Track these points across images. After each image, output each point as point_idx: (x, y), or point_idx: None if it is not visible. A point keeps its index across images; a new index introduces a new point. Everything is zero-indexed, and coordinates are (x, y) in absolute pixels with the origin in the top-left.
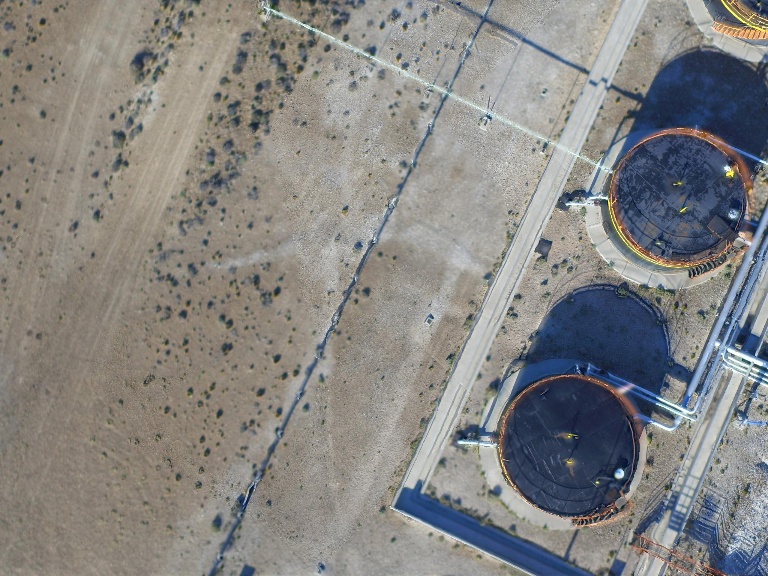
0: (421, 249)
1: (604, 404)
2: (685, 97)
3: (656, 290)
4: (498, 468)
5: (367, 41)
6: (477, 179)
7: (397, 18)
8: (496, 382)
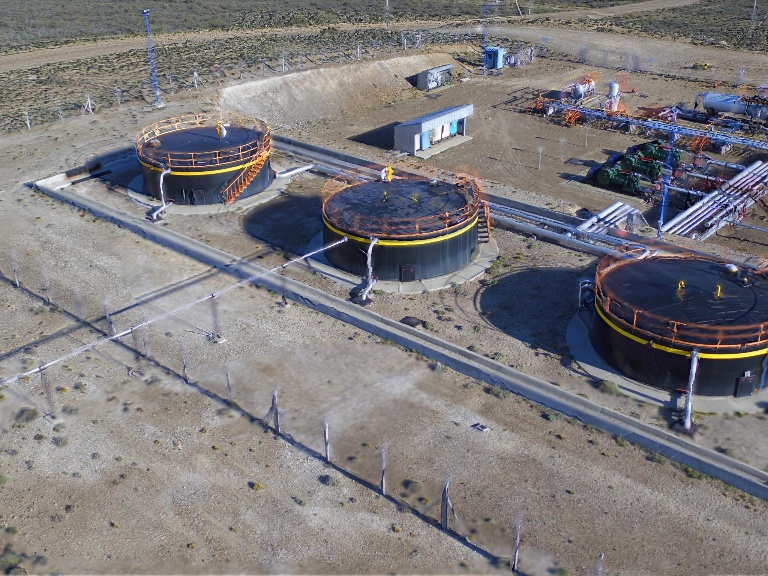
0: (364, 418)
1: (637, 270)
2: (287, 226)
3: (495, 263)
4: (728, 400)
5: (5, 414)
6: (289, 355)
7: (4, 382)
8: (593, 383)
